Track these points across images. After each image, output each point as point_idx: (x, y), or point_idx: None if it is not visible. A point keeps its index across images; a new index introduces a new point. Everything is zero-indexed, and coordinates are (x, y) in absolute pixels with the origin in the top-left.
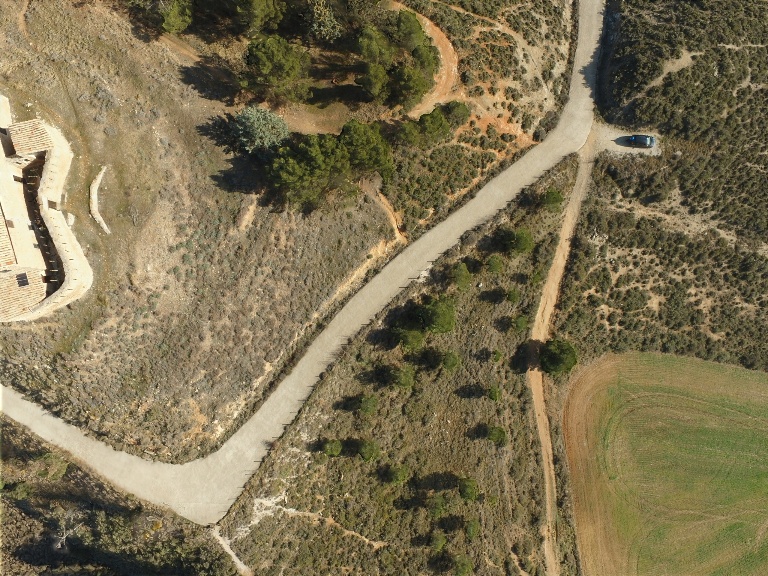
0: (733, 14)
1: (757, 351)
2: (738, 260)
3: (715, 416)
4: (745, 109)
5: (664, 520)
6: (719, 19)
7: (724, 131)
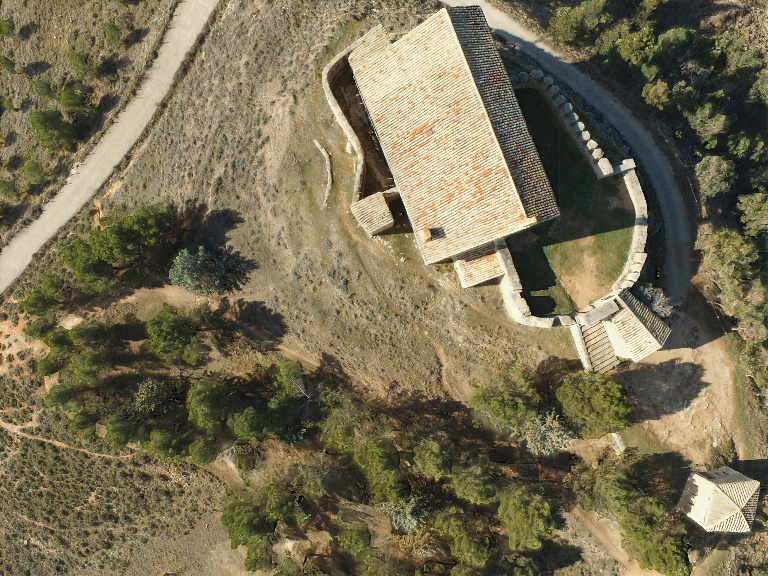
0: None
1: None
2: None
3: None
4: None
5: None
6: None
7: None
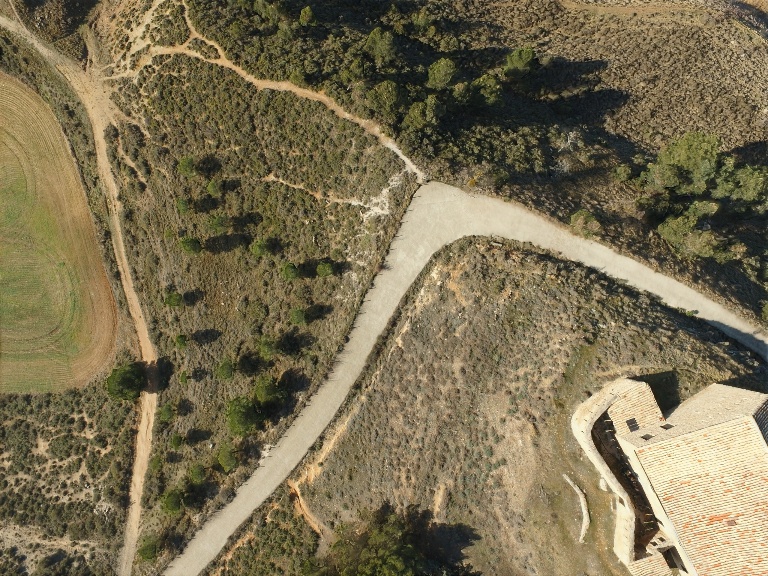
0: None
1: None
2: None
3: None
4: None
5: (7, 230)
6: None
7: None
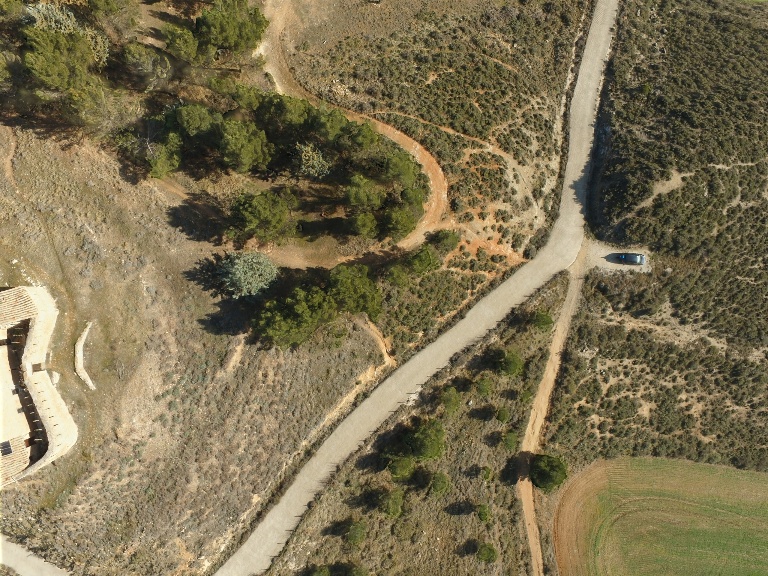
0: (723, 133)
1: (748, 452)
2: (729, 366)
3: (706, 517)
4: (735, 227)
5: None
6: (709, 138)
7: (714, 249)
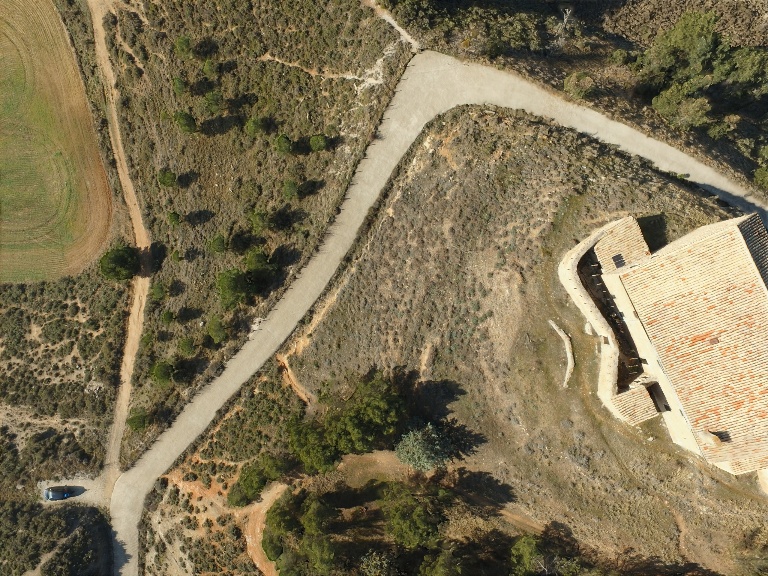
0: None
1: None
2: None
3: None
4: None
5: (5, 121)
6: None
7: None
